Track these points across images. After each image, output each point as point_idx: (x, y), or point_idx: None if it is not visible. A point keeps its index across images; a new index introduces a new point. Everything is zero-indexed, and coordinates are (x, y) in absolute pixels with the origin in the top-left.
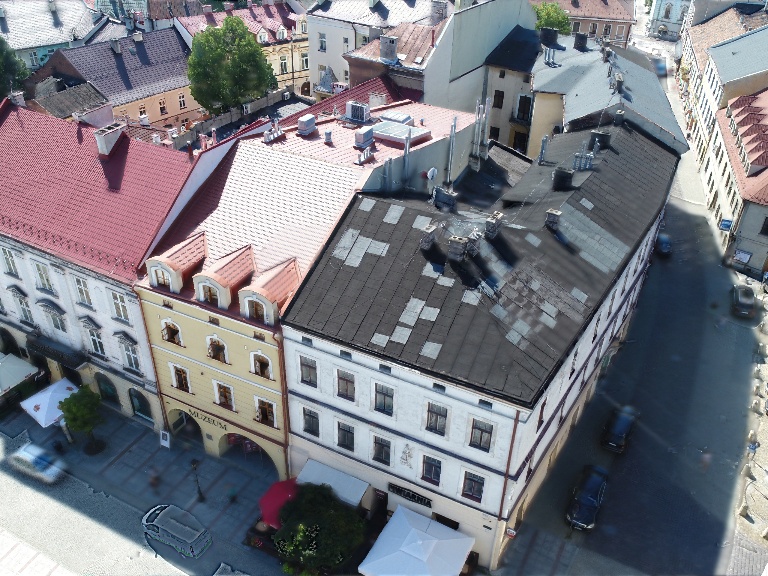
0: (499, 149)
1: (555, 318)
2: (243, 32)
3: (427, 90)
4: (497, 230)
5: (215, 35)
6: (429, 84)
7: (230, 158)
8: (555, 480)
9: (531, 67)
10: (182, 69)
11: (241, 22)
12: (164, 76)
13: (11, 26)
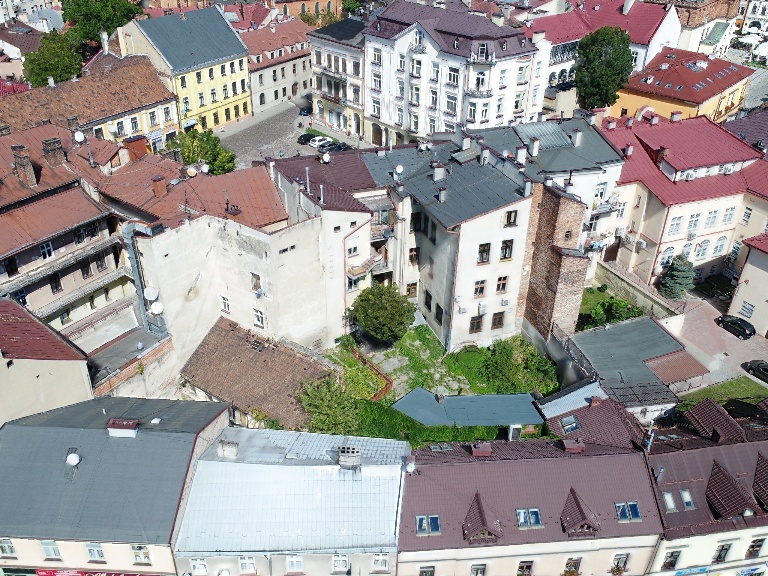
0: None
1: None
2: None
3: None
4: None
5: None
6: None
7: None
8: None
9: None
10: None
11: None
12: None
13: None
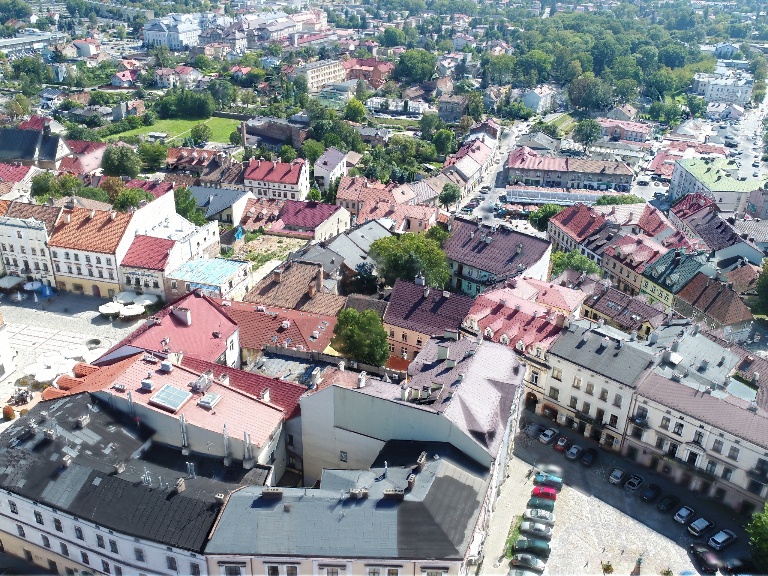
0: (266, 474)
1: (4, 473)
2: (363, 322)
3: (306, 415)
4: (49, 437)
5: (347, 314)
6: (308, 413)
7: (136, 354)
8: (28, 567)
9: (380, 466)
10: (450, 327)
11: (368, 316)
12: (434, 324)
13: (485, 250)
